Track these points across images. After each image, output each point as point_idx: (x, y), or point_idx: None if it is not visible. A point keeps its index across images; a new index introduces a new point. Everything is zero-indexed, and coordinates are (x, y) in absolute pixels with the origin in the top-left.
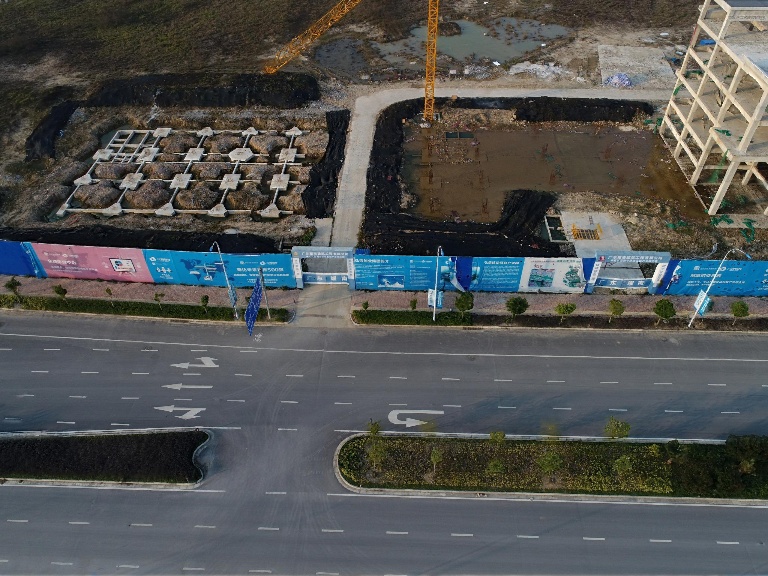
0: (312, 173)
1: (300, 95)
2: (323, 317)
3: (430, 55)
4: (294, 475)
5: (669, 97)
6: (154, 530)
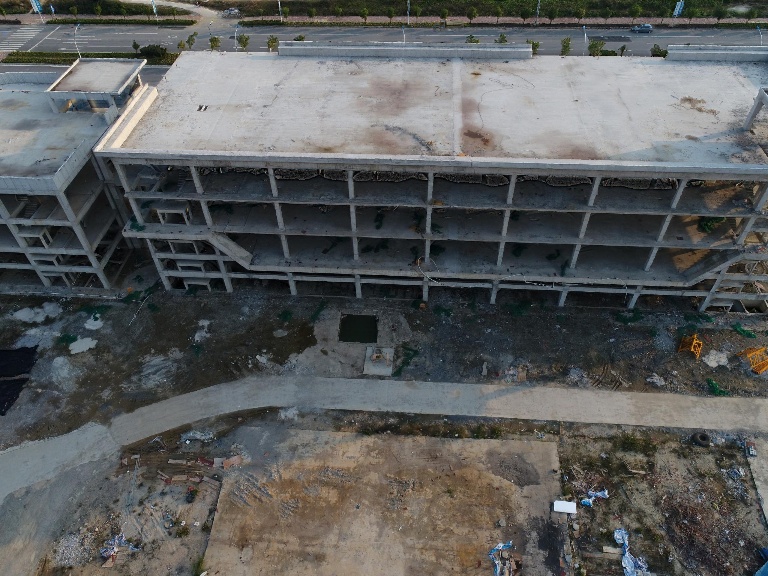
0: None
1: None
2: None
3: None
4: None
5: (766, 406)
6: None
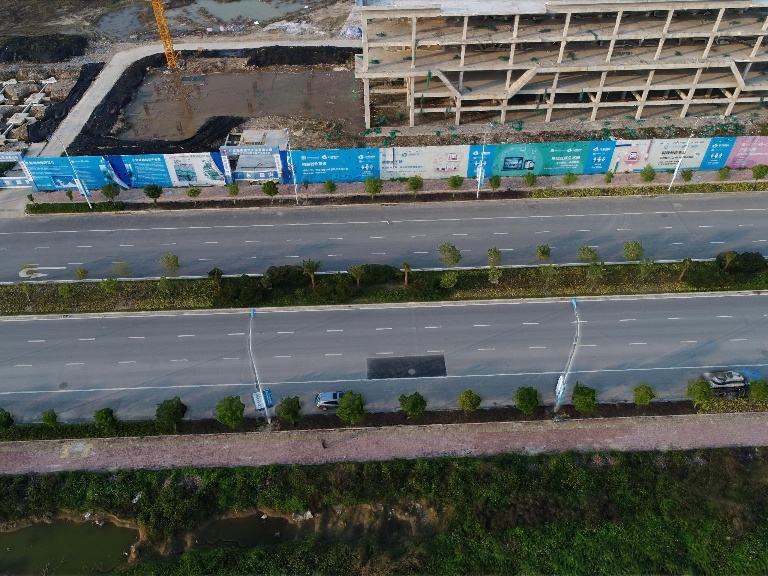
0: (47, 111)
1: (64, 51)
2: (2, 211)
3: (156, 8)
4: None
5: None
6: None
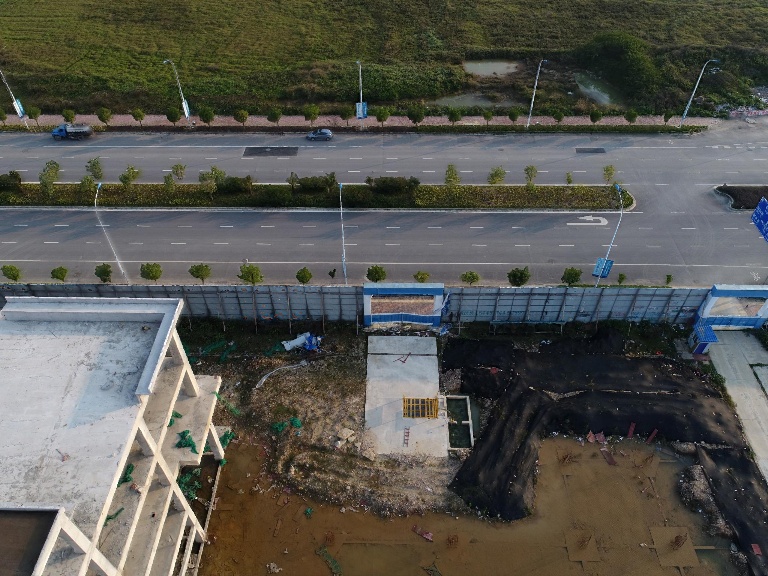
0: None
1: None
2: None
3: None
4: (656, 192)
5: None
6: (722, 170)
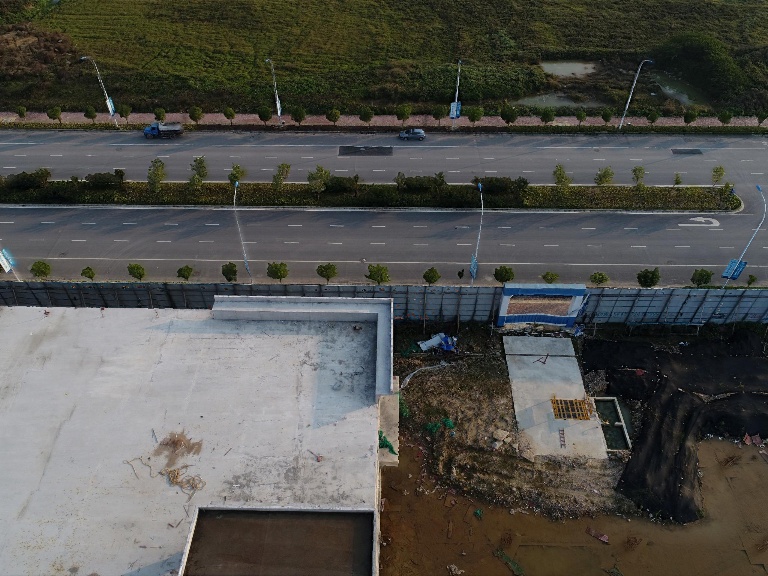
0: None
1: None
2: None
3: None
4: (762, 193)
5: None
6: None
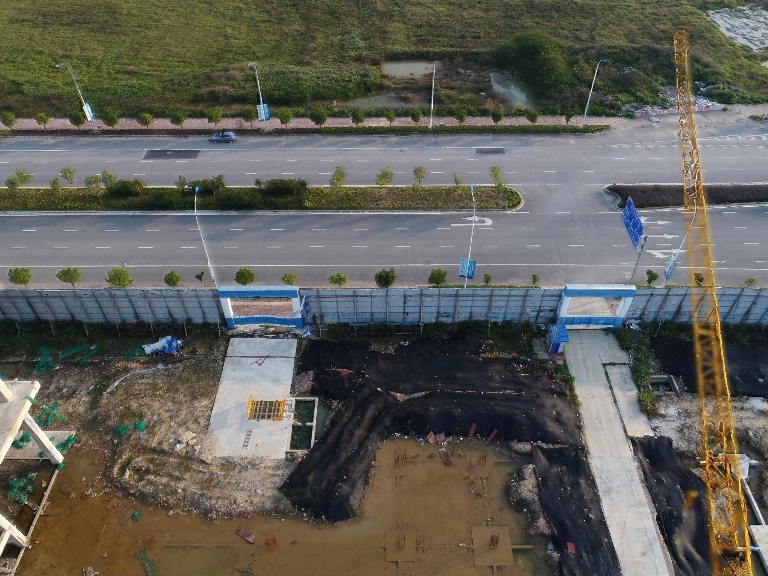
0: (727, 568)
1: None
2: None
3: None
4: (547, 192)
5: None
6: None
